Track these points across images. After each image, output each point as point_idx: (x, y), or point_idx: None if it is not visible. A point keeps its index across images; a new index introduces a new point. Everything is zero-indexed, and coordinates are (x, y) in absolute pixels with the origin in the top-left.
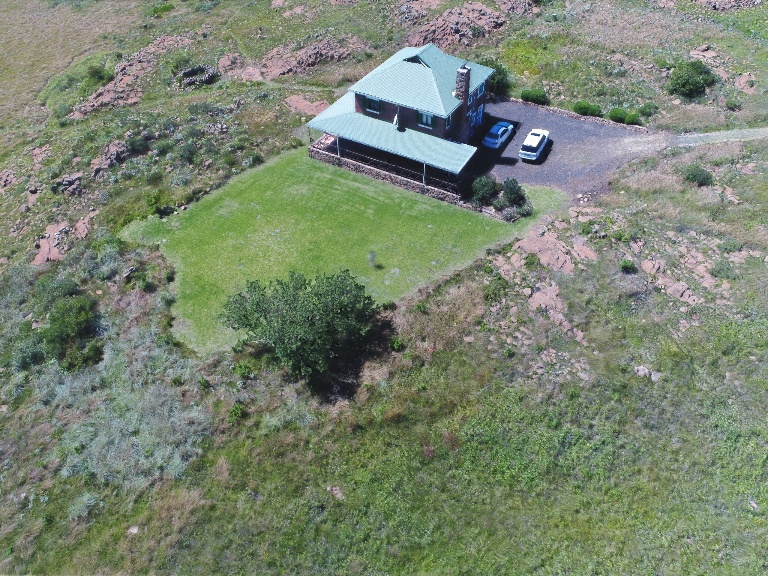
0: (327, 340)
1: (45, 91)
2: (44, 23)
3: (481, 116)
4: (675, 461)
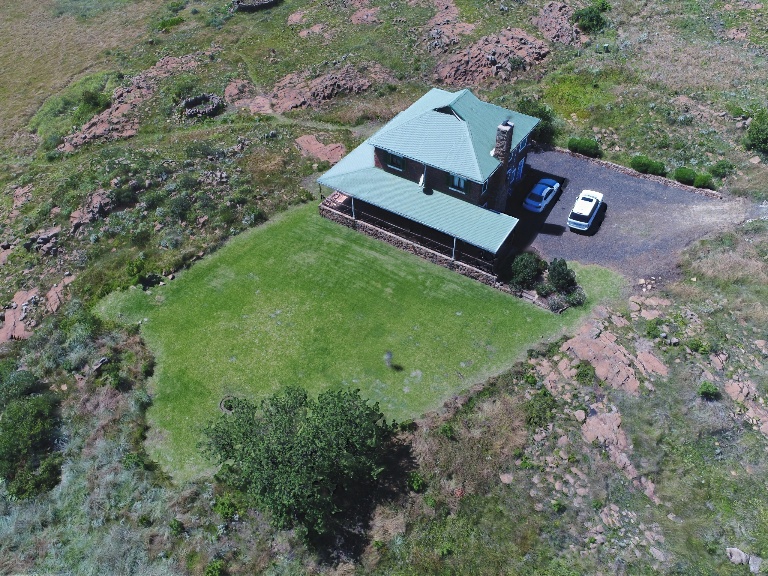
0: (329, 483)
1: (37, 116)
2: (46, 35)
3: (521, 171)
4: None
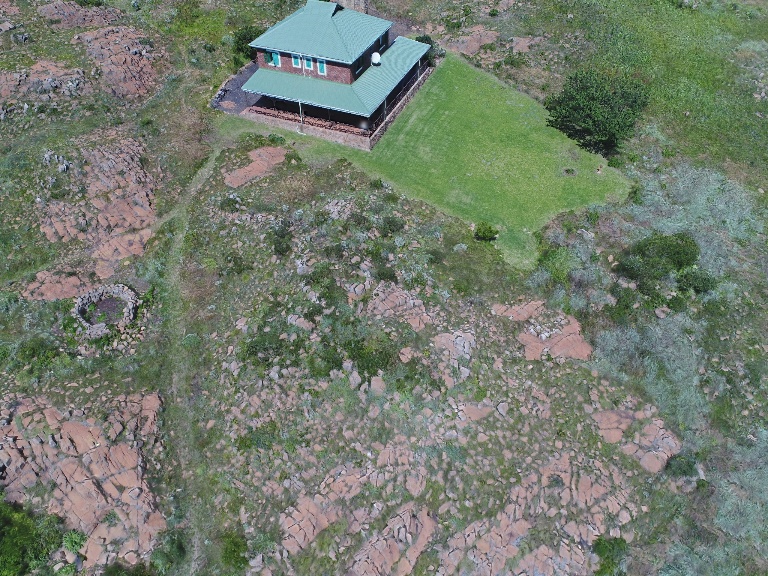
0: None
1: None
2: None
3: None
4: None
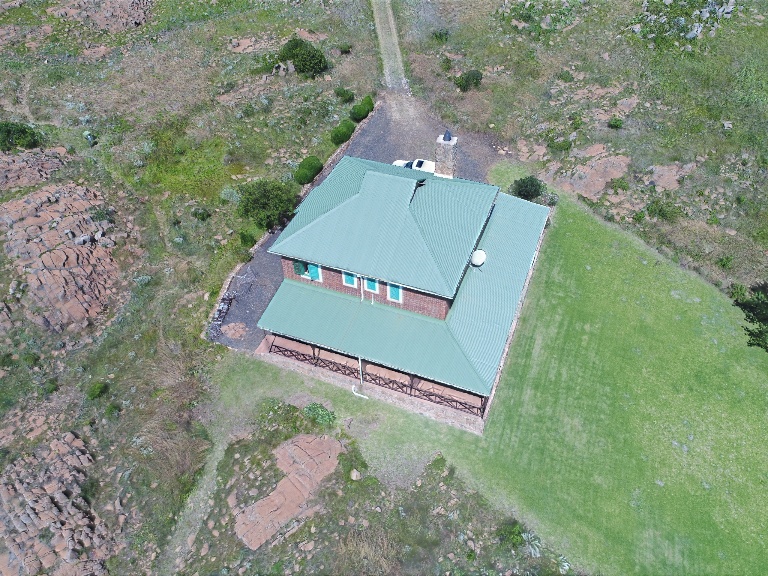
0: None
1: None
2: None
3: None
4: None
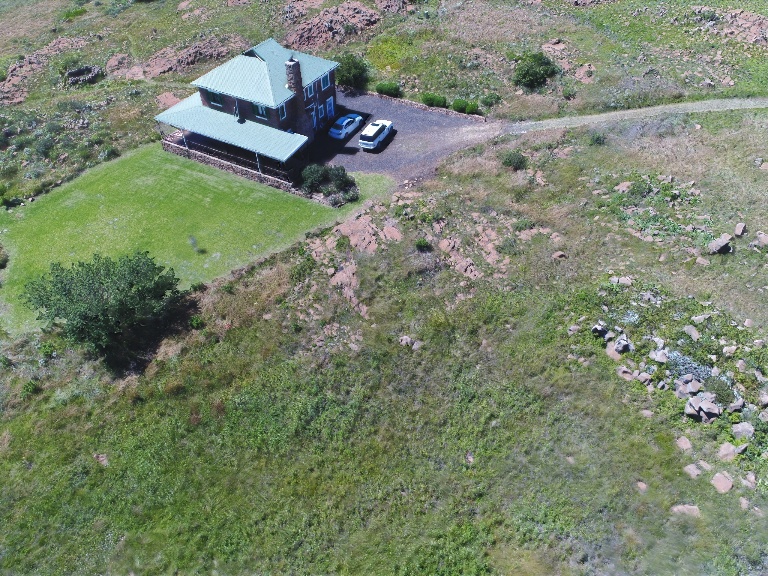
0: (120, 318)
1: None
2: None
3: (333, 109)
4: (412, 422)
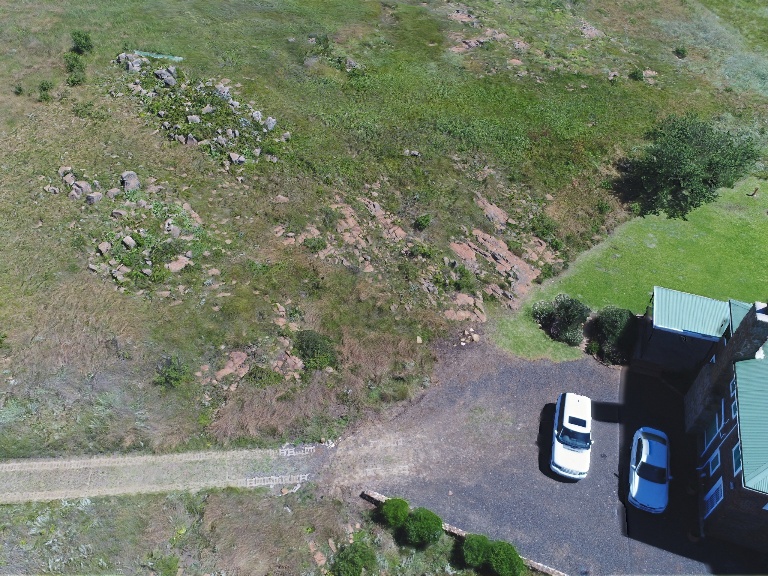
0: None
1: None
2: None
3: None
4: None
